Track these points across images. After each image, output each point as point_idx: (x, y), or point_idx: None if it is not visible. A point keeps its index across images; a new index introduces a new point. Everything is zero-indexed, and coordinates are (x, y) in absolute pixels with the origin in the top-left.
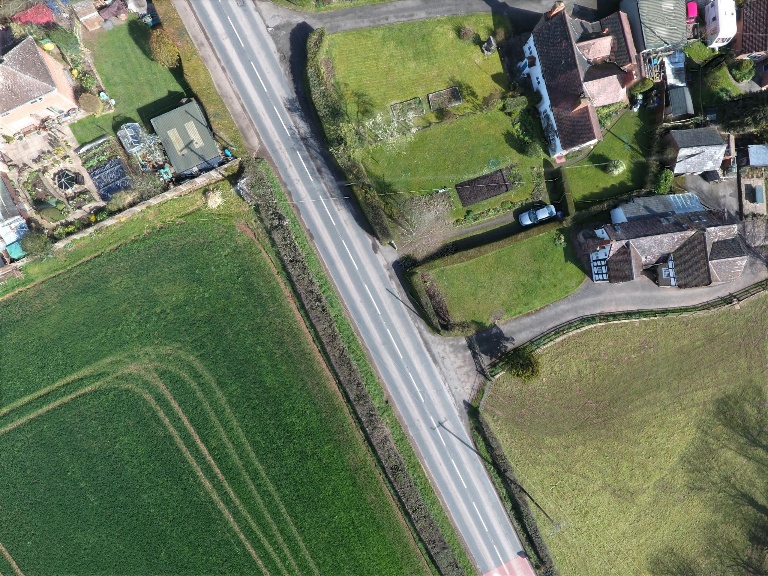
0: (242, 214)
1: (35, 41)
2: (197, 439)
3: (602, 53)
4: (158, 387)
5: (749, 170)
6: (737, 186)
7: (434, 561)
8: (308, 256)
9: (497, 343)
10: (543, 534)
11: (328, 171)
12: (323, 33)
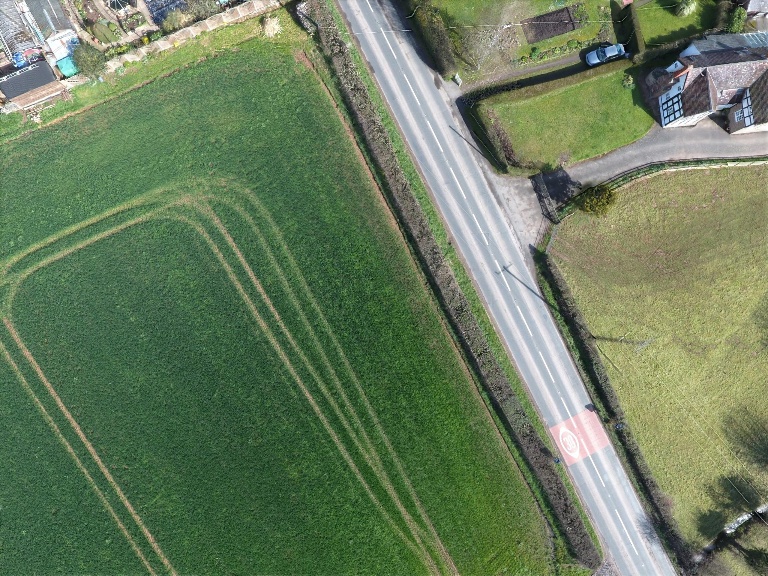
0: (300, 43)
1: None
2: (252, 276)
3: None
4: (212, 220)
5: None
6: None
7: (499, 411)
8: (369, 89)
9: (563, 187)
10: (612, 386)
11: (389, 3)
12: None
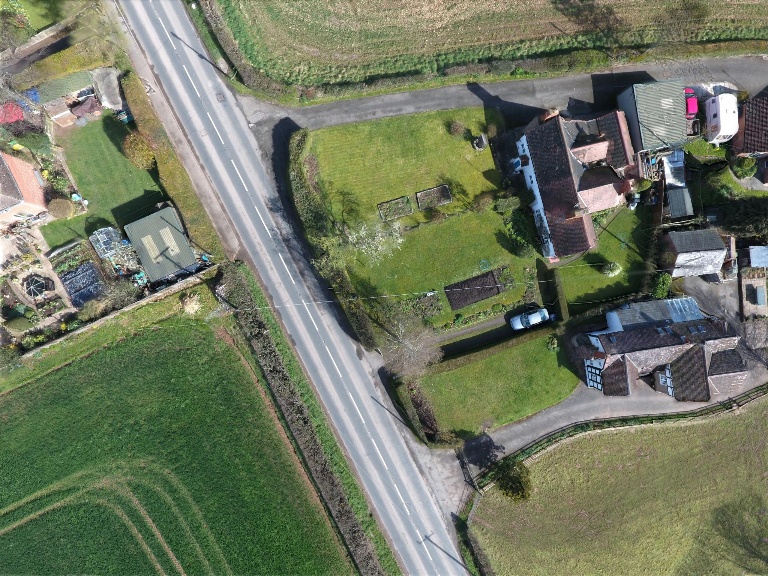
0: (221, 320)
1: (3, 143)
2: (171, 556)
3: (598, 157)
4: (131, 502)
5: (750, 271)
6: (738, 286)
7: None
8: (289, 363)
9: (487, 452)
10: None
11: (311, 274)
12: (306, 134)
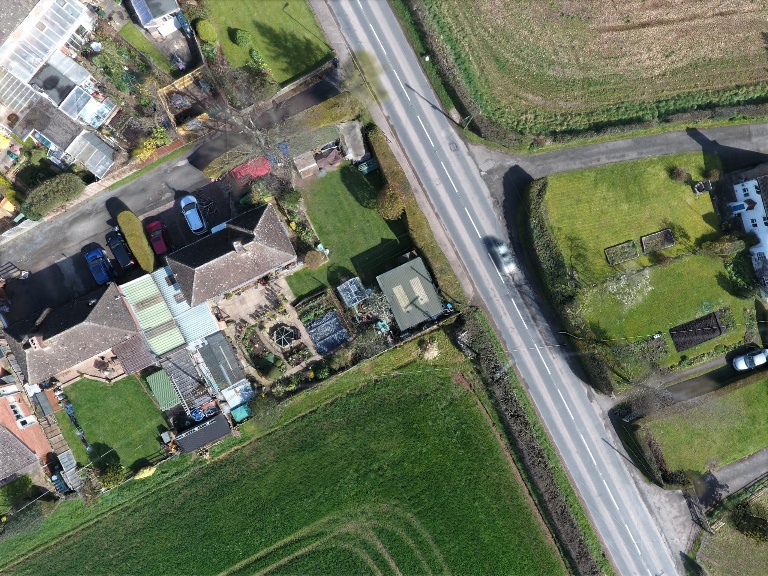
0: (458, 365)
1: None
2: None
3: None
4: (375, 546)
5: None
6: None
7: None
8: (525, 407)
9: (711, 491)
10: None
11: (543, 318)
12: (547, 183)
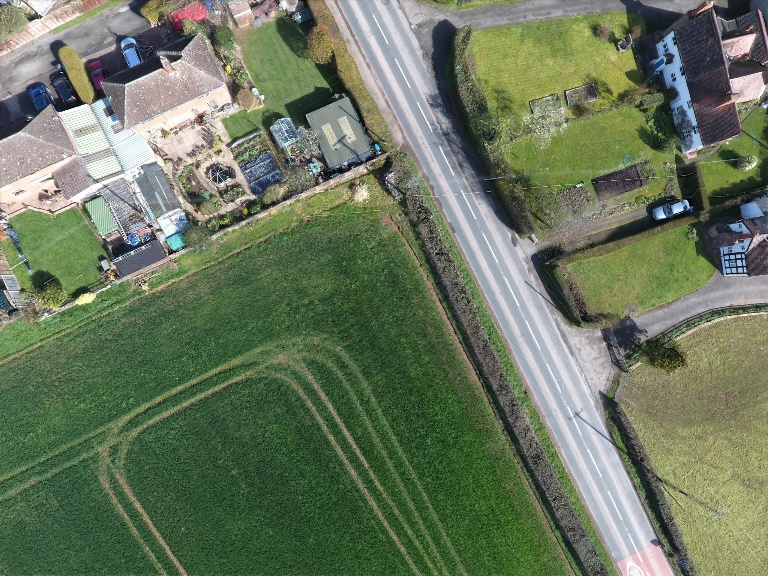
0: (387, 208)
1: None
2: (343, 428)
3: (743, 51)
4: (306, 377)
5: None
6: None
7: (571, 549)
8: (450, 249)
9: (631, 335)
10: (676, 523)
11: (469, 166)
12: (471, 30)
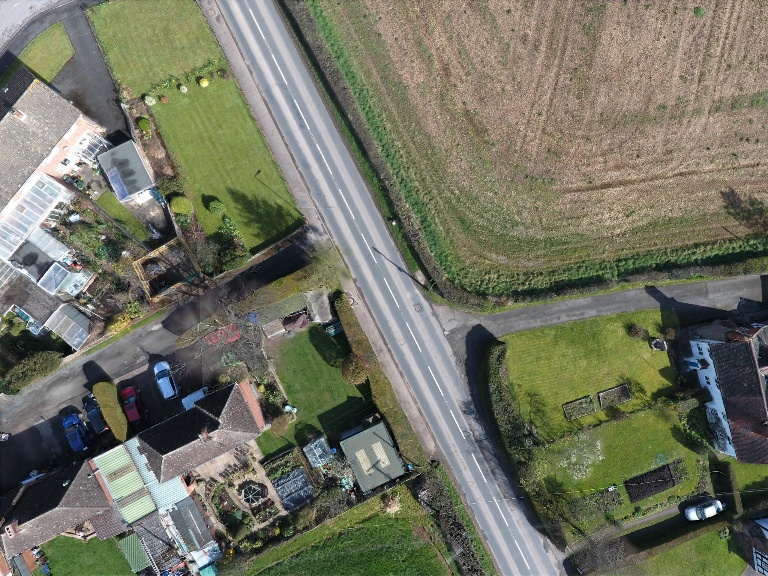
0: (419, 518)
1: None
2: None
3: None
4: None
5: None
6: None
7: None
8: (482, 558)
9: None
10: None
11: (502, 472)
12: (506, 349)
